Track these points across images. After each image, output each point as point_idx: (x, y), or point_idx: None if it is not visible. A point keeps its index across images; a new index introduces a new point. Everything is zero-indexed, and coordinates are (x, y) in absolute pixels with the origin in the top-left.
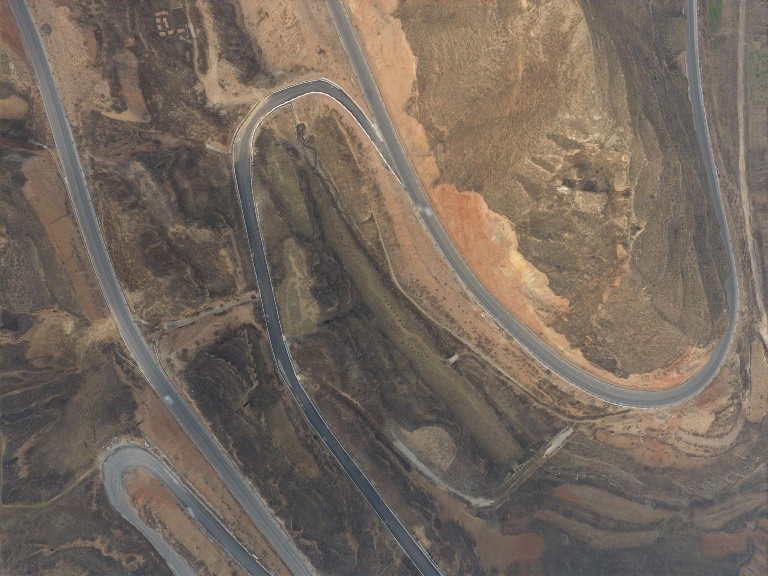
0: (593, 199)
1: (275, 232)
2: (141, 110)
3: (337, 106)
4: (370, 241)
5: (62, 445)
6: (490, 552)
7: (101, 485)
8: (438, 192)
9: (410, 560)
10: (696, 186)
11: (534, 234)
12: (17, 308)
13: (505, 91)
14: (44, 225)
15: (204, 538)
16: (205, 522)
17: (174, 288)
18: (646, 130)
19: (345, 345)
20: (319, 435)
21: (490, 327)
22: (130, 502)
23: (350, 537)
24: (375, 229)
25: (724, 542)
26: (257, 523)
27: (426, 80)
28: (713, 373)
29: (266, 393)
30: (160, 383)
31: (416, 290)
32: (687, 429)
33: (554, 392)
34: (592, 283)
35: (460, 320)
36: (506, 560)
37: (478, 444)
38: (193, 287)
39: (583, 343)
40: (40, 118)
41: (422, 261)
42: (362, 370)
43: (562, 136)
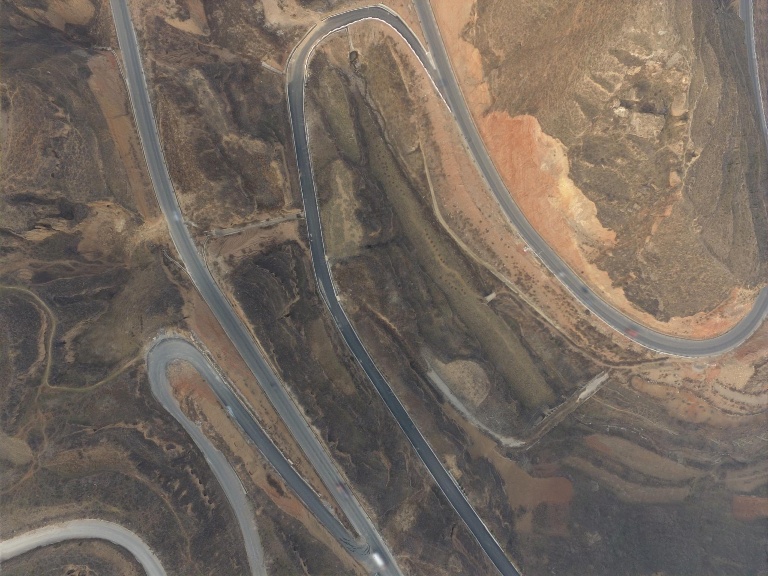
0: (650, 121)
1: (324, 153)
2: (202, 23)
3: (392, 33)
4: (415, 173)
5: (109, 333)
6: (519, 492)
7: (145, 375)
8: (488, 121)
9: (440, 489)
10: (750, 126)
11: (587, 158)
12: (74, 196)
13: (567, 10)
14: (106, 118)
15: (241, 438)
16: (243, 422)
17: (225, 193)
18: (708, 54)
19: (386, 270)
20: (356, 357)
21: (531, 262)
22: (172, 393)
23: (383, 456)
24: (421, 160)
25: (755, 506)
26: (293, 431)
27: (486, 2)
28: (754, 326)
29: (307, 308)
30: (206, 285)
31: (459, 222)
32: (725, 382)
33: (592, 334)
34: (641, 213)
35: (501, 254)
36: (535, 501)
37: (510, 386)
38: (243, 195)
39: (626, 282)
40: (106, 21)
41: (467, 191)
42: (401, 298)
43: (625, 52)
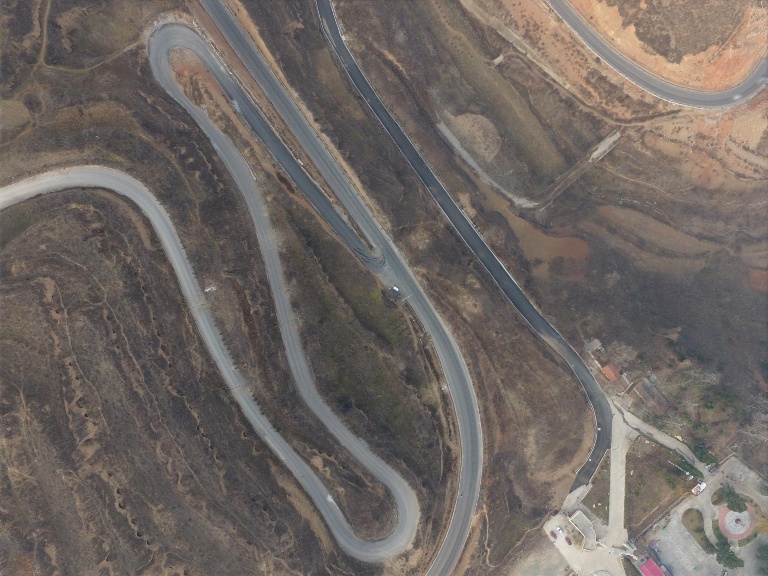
0: None
1: None
2: None
3: None
4: None
5: (107, 20)
6: (533, 248)
7: (146, 60)
8: None
9: (454, 229)
10: None
11: None
12: None
13: None
14: None
15: (249, 134)
16: (250, 118)
17: None
18: None
19: (391, 13)
20: (363, 97)
21: (540, 7)
22: (175, 78)
23: None
24: None
25: None
26: (302, 142)
27: None
28: (766, 79)
29: (312, 38)
30: None
31: None
32: (738, 140)
33: (603, 86)
34: None
35: (508, 3)
36: (550, 255)
37: (521, 153)
38: None
39: (636, 17)
40: None
41: None
42: None
43: None
